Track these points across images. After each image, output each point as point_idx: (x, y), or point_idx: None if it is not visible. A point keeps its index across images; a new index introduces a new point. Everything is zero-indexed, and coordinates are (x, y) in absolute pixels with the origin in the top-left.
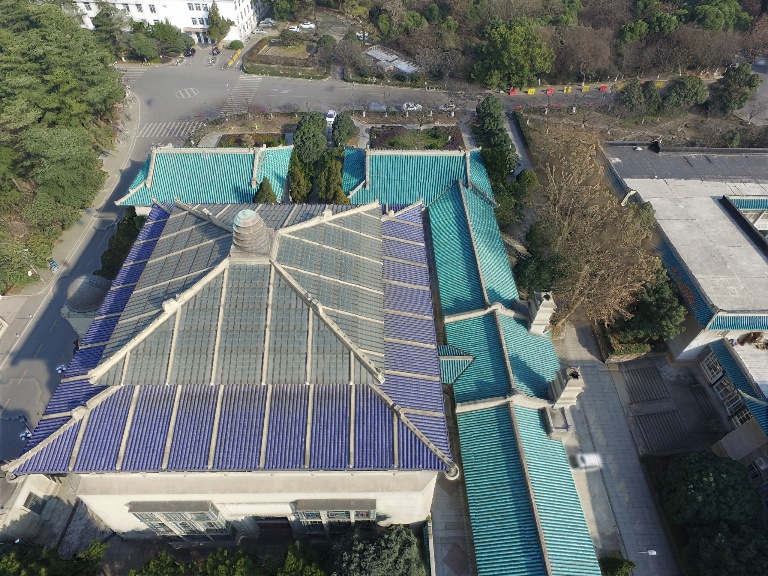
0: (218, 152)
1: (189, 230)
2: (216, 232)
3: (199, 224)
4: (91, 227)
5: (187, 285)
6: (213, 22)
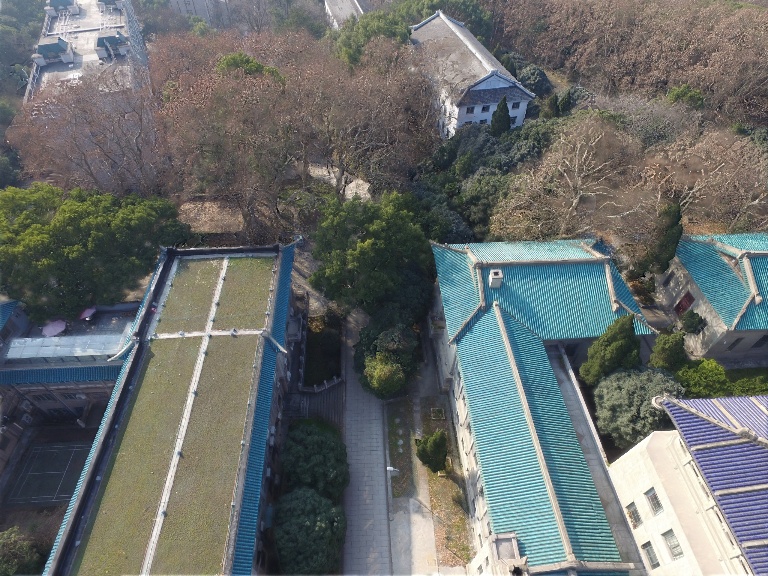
0: None
1: None
2: None
3: None
4: None
5: None
6: None
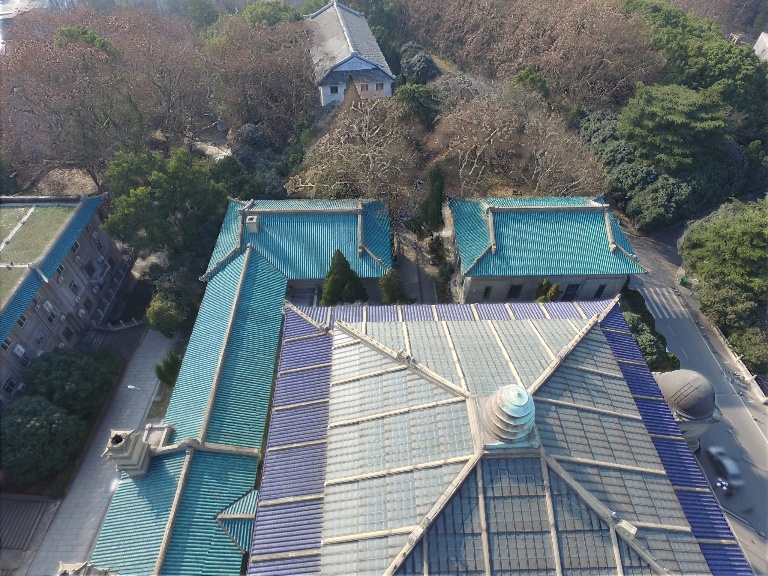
0: None
1: (644, 522)
2: (584, 483)
3: (632, 523)
4: None
5: (566, 388)
6: None
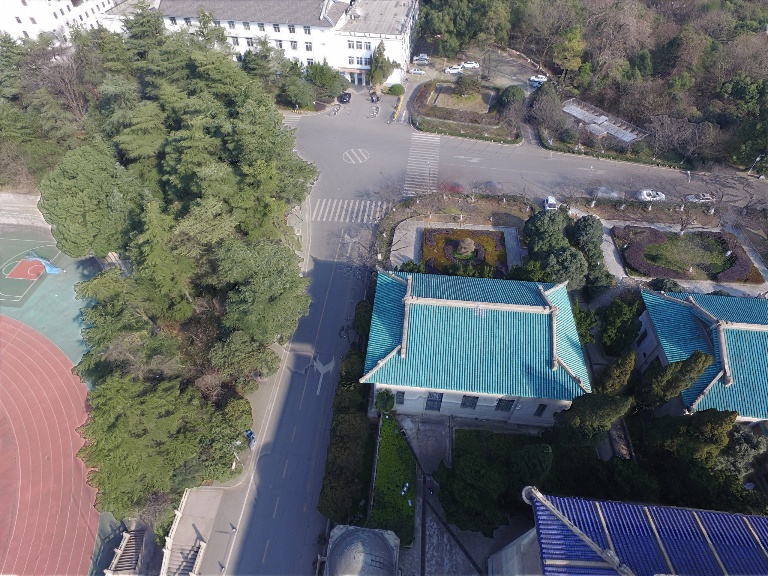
0: (497, 308)
1: None
2: None
3: None
4: (285, 367)
5: None
6: (377, 64)
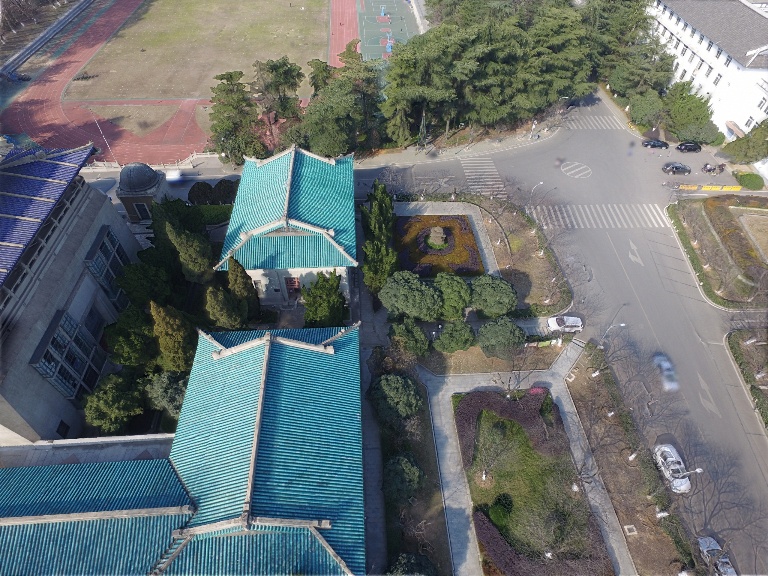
0: None
1: None
2: None
3: None
4: None
5: None
6: (751, 135)
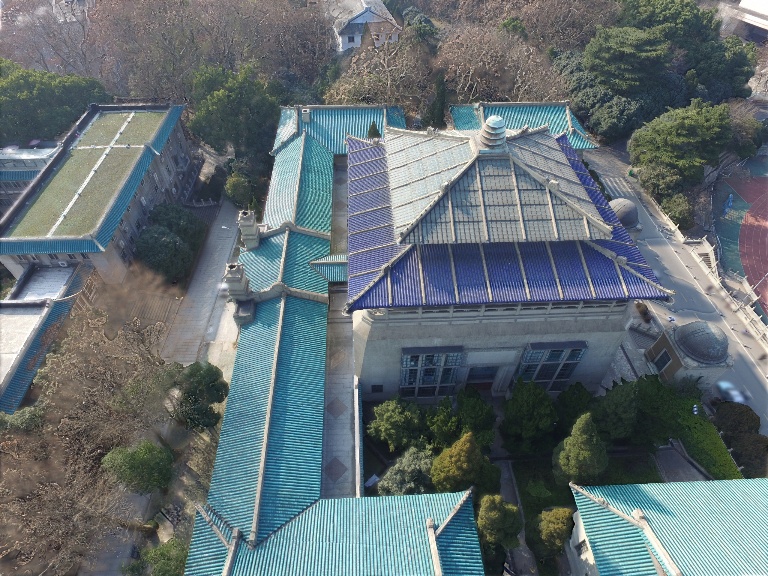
0: None
1: None
2: None
3: None
4: None
5: (526, 144)
6: None
